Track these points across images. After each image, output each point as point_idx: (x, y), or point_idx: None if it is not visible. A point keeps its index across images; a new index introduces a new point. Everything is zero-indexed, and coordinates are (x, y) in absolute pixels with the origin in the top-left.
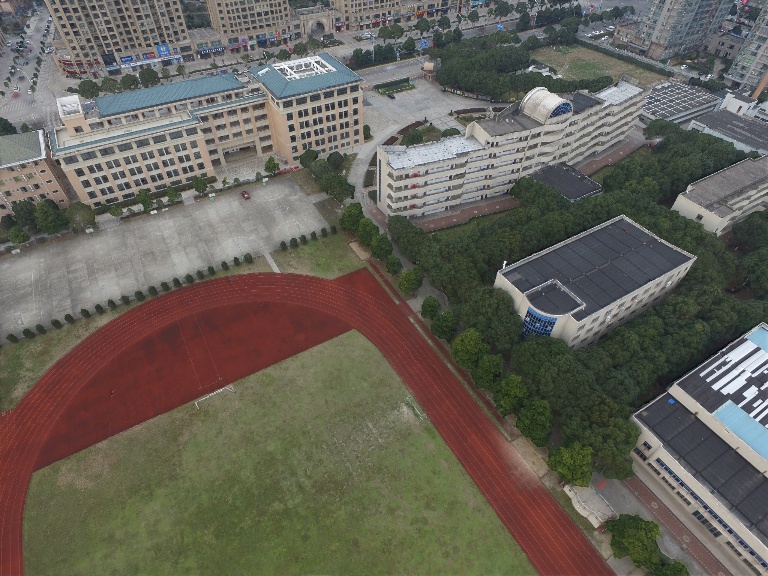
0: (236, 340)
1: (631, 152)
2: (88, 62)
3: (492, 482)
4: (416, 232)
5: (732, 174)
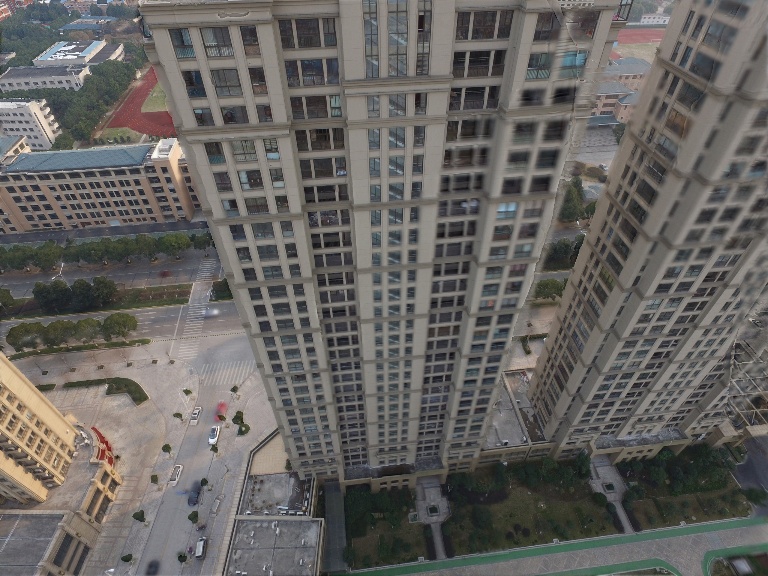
0: None
1: None
2: None
3: None
4: None
5: None
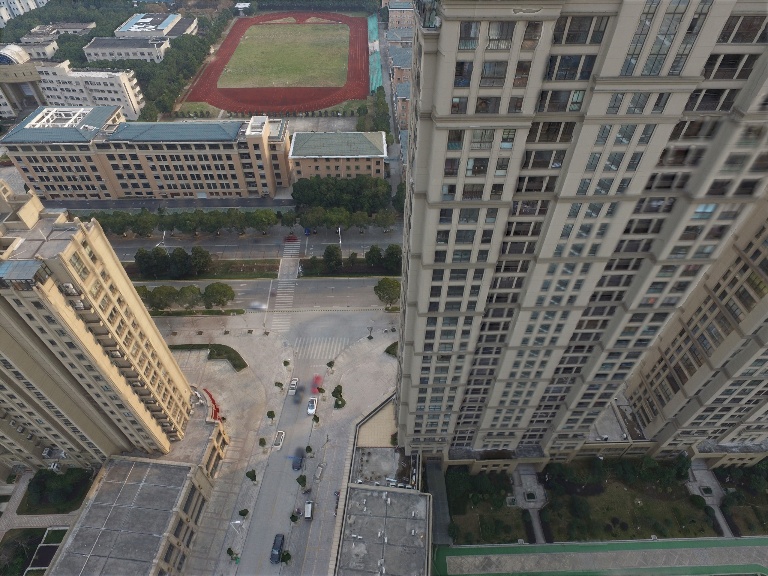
0: None
1: None
2: None
3: (225, 58)
4: None
5: None
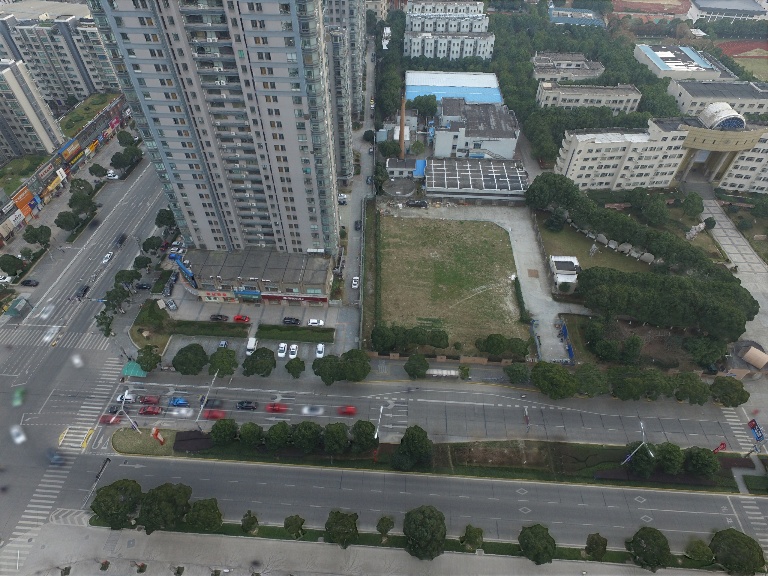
0: None
1: None
2: None
3: None
4: None
5: (588, 93)
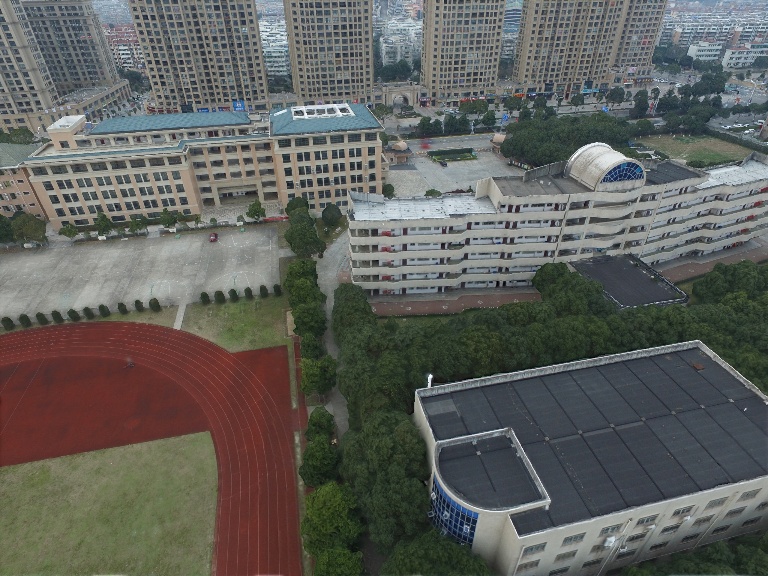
0: (55, 406)
1: (760, 261)
2: (168, 110)
3: None
4: (357, 308)
5: None
